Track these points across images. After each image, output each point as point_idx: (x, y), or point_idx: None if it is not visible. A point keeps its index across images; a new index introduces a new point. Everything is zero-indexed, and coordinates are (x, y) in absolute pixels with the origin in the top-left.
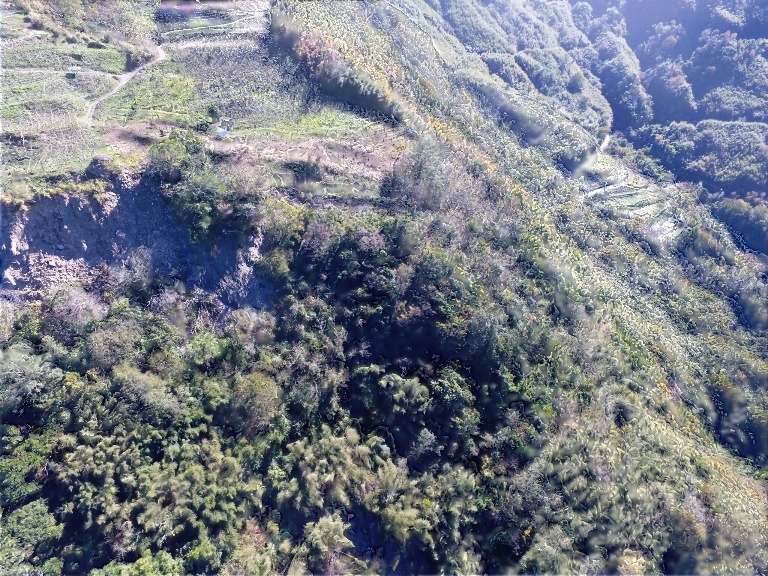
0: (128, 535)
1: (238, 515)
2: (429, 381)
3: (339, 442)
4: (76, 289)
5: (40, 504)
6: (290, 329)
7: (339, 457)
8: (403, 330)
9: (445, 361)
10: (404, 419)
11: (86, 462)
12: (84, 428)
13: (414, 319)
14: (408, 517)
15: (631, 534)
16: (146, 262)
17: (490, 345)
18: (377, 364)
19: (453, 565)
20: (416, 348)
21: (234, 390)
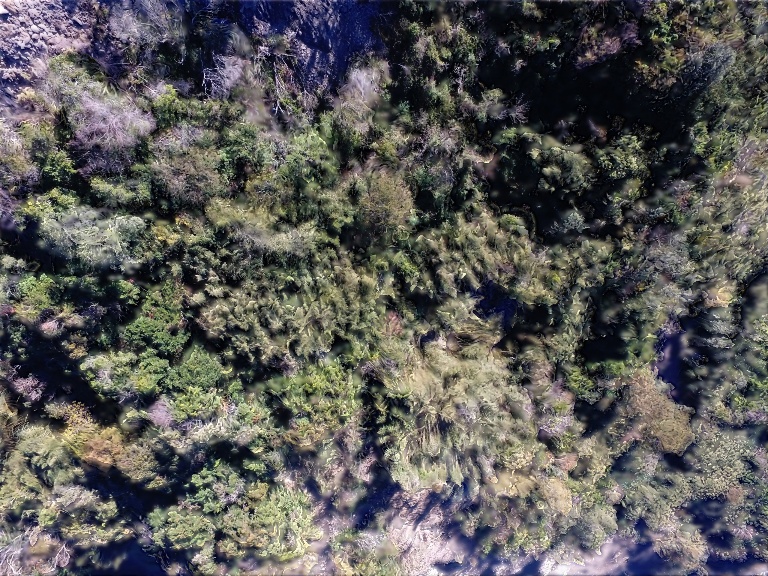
0: (291, 363)
1: (381, 323)
2: (598, 157)
3: (479, 242)
4: (91, 98)
5: (200, 355)
6: (412, 82)
7: (477, 255)
8: (578, 69)
9: (628, 126)
10: (551, 198)
11: (228, 320)
12: (207, 286)
13: (604, 58)
14: (537, 296)
15: (735, 274)
16: (172, 10)
17: (701, 96)
18: (532, 132)
19: (564, 317)
20: (589, 100)
21: (360, 208)
